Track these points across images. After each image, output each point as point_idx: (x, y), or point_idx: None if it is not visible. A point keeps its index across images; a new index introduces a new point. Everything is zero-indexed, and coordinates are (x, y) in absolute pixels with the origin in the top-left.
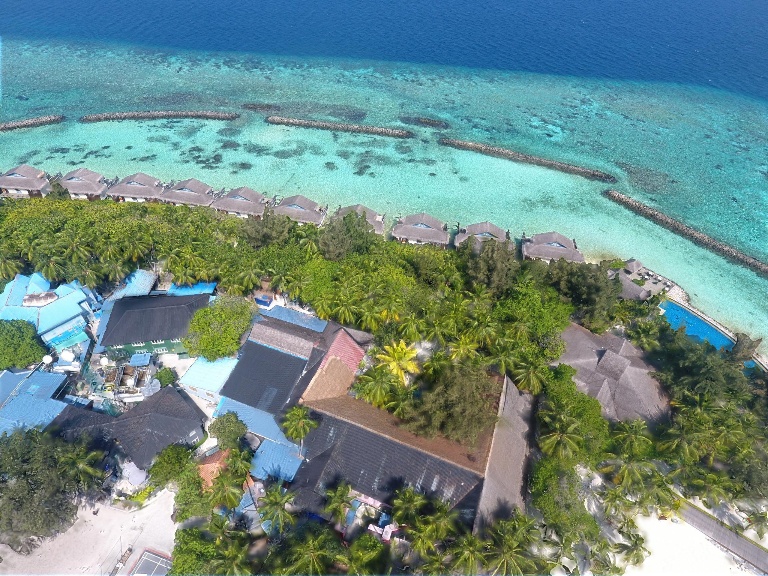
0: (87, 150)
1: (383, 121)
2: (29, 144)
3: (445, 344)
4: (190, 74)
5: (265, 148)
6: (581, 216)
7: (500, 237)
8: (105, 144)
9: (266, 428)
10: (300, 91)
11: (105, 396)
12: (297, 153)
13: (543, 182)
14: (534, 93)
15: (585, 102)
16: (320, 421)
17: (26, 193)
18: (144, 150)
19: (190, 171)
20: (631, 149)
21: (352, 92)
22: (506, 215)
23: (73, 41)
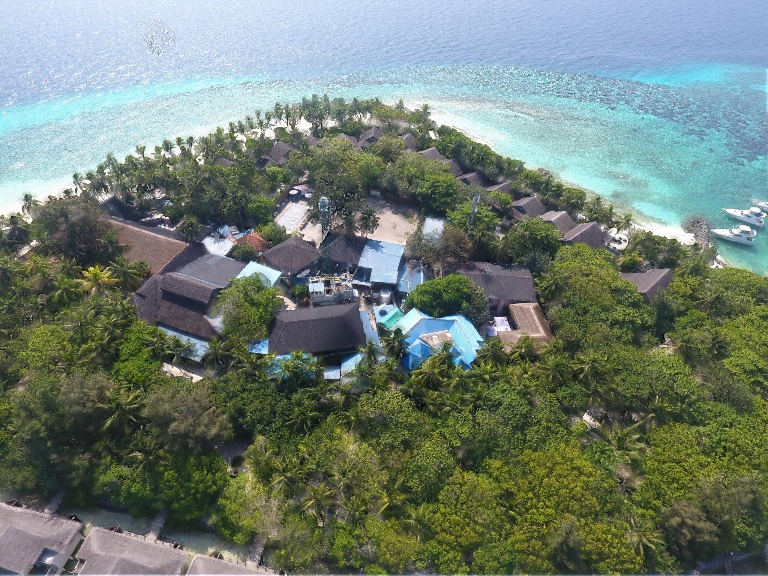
0: None
1: None
2: None
3: None
4: None
5: None
6: None
7: None
8: None
9: None
10: None
11: None
12: None
13: None
14: None
15: None
16: None
17: None
18: None
19: None
20: None
21: None
22: None
23: None
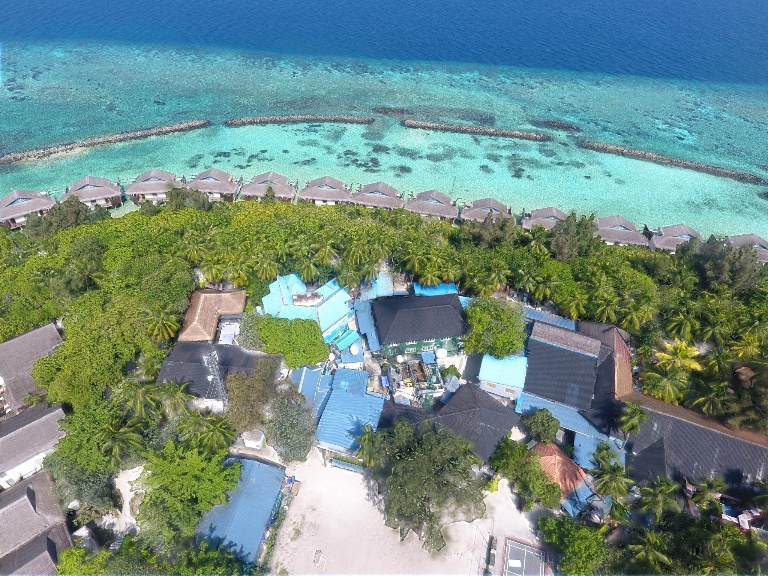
0: (247, 154)
1: (514, 124)
2: (190, 148)
3: (724, 343)
4: (306, 78)
5: (415, 151)
6: (750, 218)
7: (700, 239)
8: (261, 148)
9: (575, 423)
10: (420, 95)
11: (406, 392)
12: (448, 156)
13: (697, 184)
14: (645, 96)
15: (699, 105)
16: (642, 416)
17: (218, 196)
18: (301, 154)
19: (355, 174)
20: (766, 152)
21: (470, 96)
22: (678, 217)
23: (178, 46)
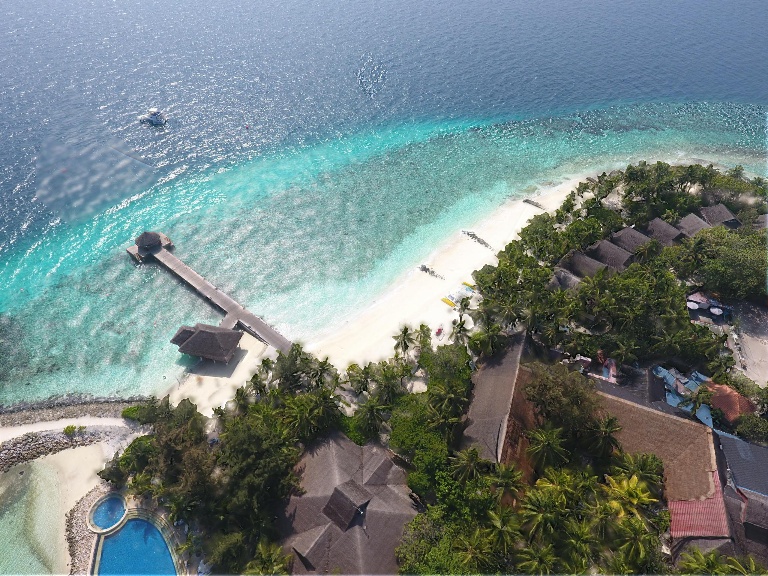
0: None
1: None
2: None
3: None
4: None
5: None
6: None
7: None
8: None
9: None
10: None
11: None
12: None
13: None
14: None
15: None
16: (677, 414)
17: None
18: None
19: None
20: None
21: None
22: None
23: None
